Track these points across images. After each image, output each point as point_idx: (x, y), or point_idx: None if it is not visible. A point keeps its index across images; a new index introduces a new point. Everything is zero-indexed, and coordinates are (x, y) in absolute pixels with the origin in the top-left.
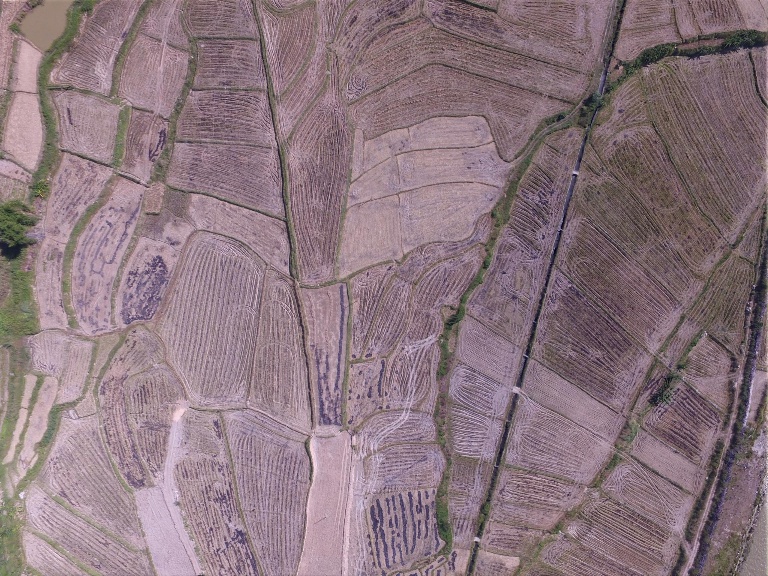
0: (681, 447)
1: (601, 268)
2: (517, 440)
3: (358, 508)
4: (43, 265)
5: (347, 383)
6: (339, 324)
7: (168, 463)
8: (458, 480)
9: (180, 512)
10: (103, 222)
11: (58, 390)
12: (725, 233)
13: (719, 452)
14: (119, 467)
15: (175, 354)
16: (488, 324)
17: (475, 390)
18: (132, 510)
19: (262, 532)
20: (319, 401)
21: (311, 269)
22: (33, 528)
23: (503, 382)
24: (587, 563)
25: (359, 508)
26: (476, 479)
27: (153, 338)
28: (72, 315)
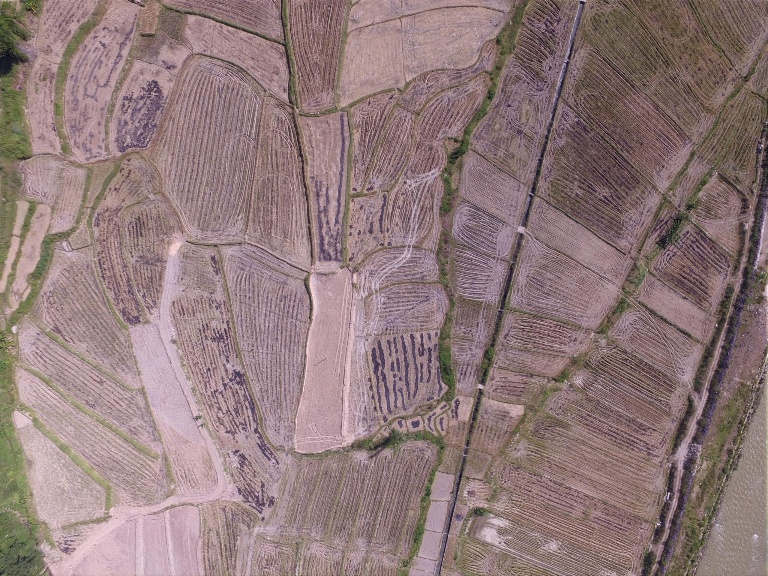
0: (690, 293)
1: (609, 101)
2: (522, 282)
3: (359, 350)
4: (35, 86)
5: (348, 217)
6: (340, 155)
7: (164, 299)
8: (461, 324)
9: (177, 350)
10: (97, 43)
11: (51, 219)
12: (737, 65)
13: (729, 297)
14: (114, 303)
15: (171, 185)
16: (493, 160)
17: (479, 229)
18: (127, 347)
19: (261, 373)
20: (319, 236)
21: (311, 96)
22: (26, 364)
23: (508, 221)
24: (593, 414)
25: (360, 350)
26: (480, 323)
27: (148, 167)
28: (65, 140)
